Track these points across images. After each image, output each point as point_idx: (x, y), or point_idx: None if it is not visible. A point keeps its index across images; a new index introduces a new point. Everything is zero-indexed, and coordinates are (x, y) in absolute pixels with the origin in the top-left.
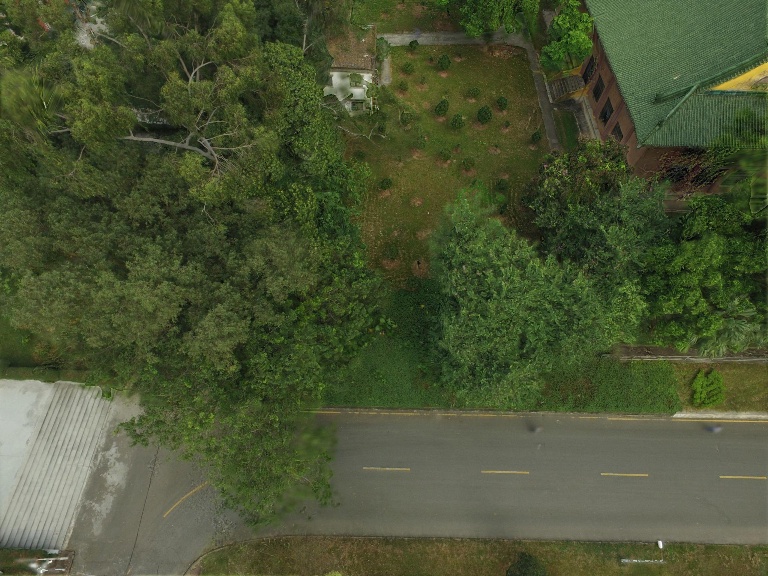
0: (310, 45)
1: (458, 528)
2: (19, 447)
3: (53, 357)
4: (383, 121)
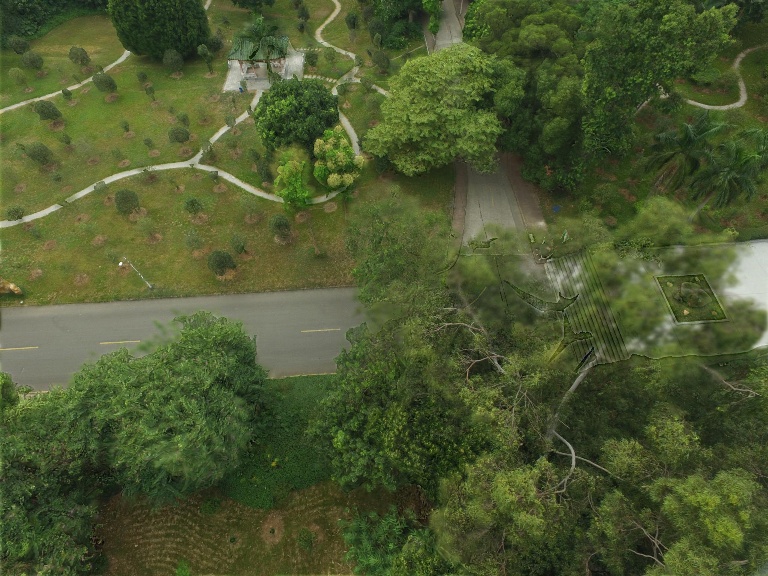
0: None
1: (267, 298)
2: (622, 309)
3: (656, 384)
4: None
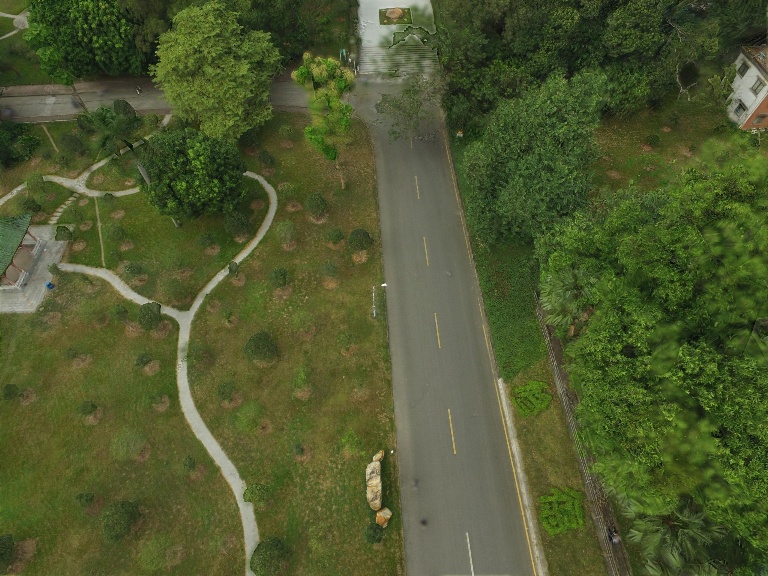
0: (766, 33)
1: (386, 225)
2: None
3: None
4: (739, 138)
